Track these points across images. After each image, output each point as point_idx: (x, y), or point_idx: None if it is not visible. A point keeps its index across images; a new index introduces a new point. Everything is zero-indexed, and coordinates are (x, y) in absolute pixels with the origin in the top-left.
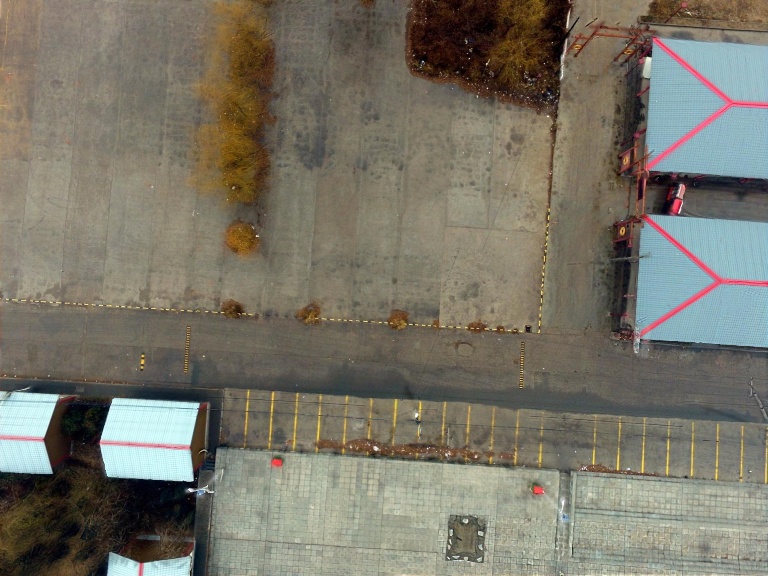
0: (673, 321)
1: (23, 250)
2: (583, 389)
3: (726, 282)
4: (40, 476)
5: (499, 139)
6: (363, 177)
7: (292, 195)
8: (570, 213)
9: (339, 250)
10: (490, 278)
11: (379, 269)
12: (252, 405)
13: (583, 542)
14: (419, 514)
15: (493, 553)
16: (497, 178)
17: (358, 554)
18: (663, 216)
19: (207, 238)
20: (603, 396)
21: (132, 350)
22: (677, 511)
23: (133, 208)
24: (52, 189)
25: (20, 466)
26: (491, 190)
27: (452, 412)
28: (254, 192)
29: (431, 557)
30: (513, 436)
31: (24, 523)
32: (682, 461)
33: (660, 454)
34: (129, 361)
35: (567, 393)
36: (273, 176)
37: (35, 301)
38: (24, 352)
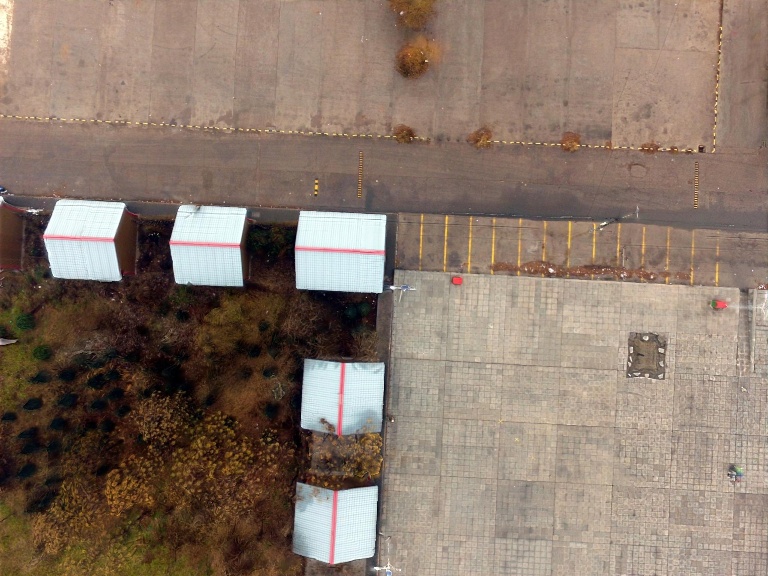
0: None
1: (195, 78)
2: (759, 208)
3: None
4: (230, 289)
5: None
6: (531, 0)
7: (460, 20)
8: (742, 31)
9: (509, 73)
10: (662, 98)
11: (550, 92)
12: (426, 229)
13: (764, 359)
14: (599, 332)
15: (674, 370)
16: None
17: (538, 372)
18: None
19: (377, 63)
20: None
21: (305, 176)
22: None
23: (302, 35)
24: (221, 17)
25: (212, 278)
26: (660, 11)
27: (627, 233)
28: (422, 17)
29: (612, 374)
30: (689, 256)
31: (235, 316)
32: None
33: None
34: (303, 187)
35: (742, 212)
36: (440, 1)
37: (209, 127)
38: (199, 179)
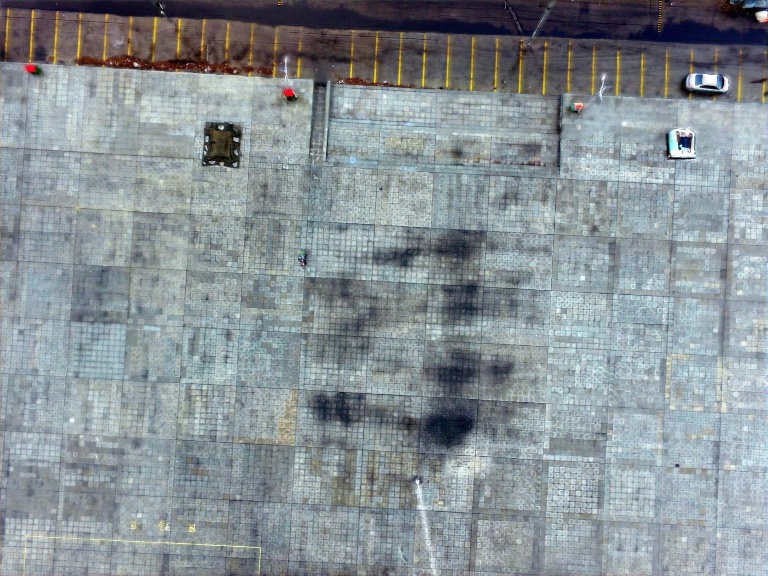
0: None
1: None
2: (340, 5)
3: None
4: None
5: None
6: None
7: None
8: None
9: None
10: None
11: None
12: (12, 23)
13: (338, 149)
14: (175, 122)
15: (248, 158)
16: None
17: (116, 161)
18: None
19: None
20: (360, 12)
21: None
22: (431, 119)
23: None
24: None
25: None
26: None
27: (211, 29)
28: None
29: (188, 163)
30: (271, 51)
31: None
32: (438, 73)
33: (416, 67)
34: None
35: (325, 9)
36: None
37: None
38: None
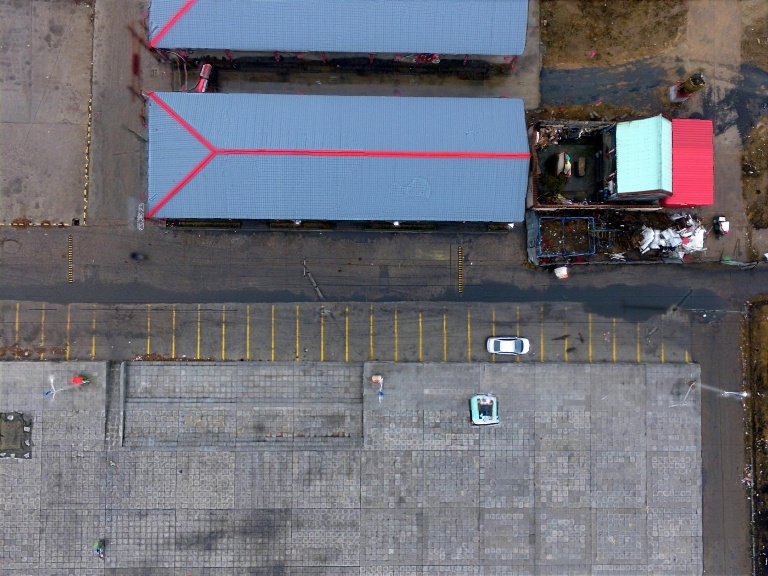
0: (182, 197)
1: None
2: (135, 279)
3: (221, 152)
4: None
5: (38, 31)
6: None
7: None
8: (113, 102)
9: None
10: (33, 173)
11: None
12: None
13: (136, 431)
14: None
15: (41, 448)
16: (38, 71)
17: None
18: (171, 93)
19: None
20: (155, 285)
21: None
22: (232, 394)
23: None
24: None
25: None
26: (32, 84)
27: None
28: None
29: None
30: (64, 331)
31: None
32: (238, 344)
33: (215, 339)
34: None
35: (119, 284)
36: None
37: None
38: None
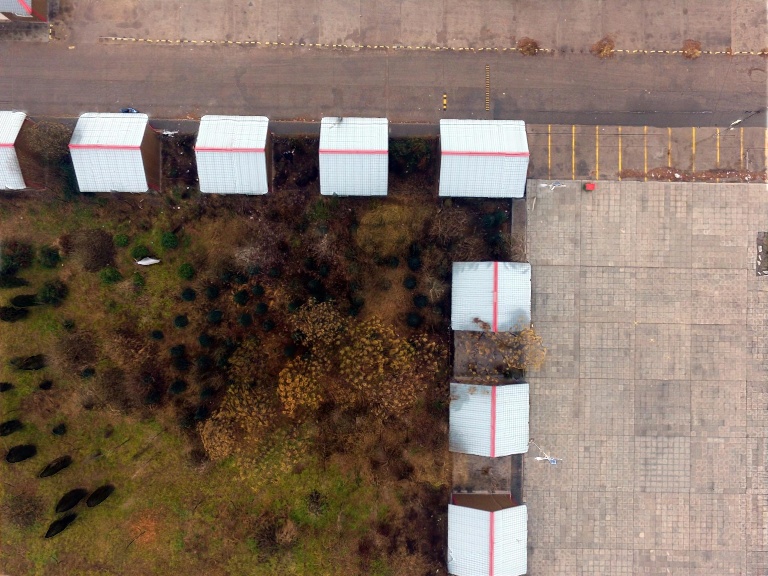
0: None
1: None
2: None
3: None
4: (375, 198)
5: None
6: None
7: None
8: None
9: None
10: None
11: (669, 1)
12: (554, 139)
13: None
14: (728, 233)
15: None
16: None
17: (671, 274)
18: None
19: None
20: None
21: (434, 91)
22: None
23: None
24: None
25: (357, 187)
26: None
27: (749, 137)
28: None
29: (742, 274)
30: None
31: (395, 215)
32: None
33: None
34: (432, 102)
35: None
36: None
37: (338, 45)
38: (330, 97)
